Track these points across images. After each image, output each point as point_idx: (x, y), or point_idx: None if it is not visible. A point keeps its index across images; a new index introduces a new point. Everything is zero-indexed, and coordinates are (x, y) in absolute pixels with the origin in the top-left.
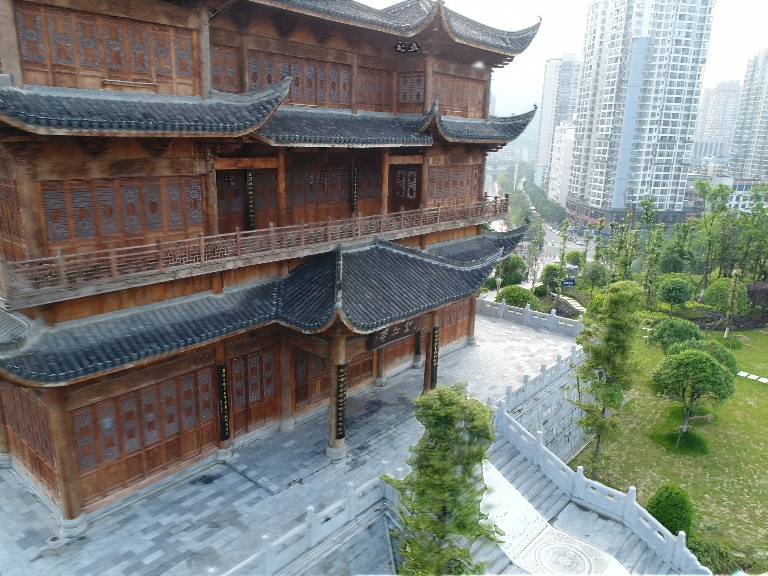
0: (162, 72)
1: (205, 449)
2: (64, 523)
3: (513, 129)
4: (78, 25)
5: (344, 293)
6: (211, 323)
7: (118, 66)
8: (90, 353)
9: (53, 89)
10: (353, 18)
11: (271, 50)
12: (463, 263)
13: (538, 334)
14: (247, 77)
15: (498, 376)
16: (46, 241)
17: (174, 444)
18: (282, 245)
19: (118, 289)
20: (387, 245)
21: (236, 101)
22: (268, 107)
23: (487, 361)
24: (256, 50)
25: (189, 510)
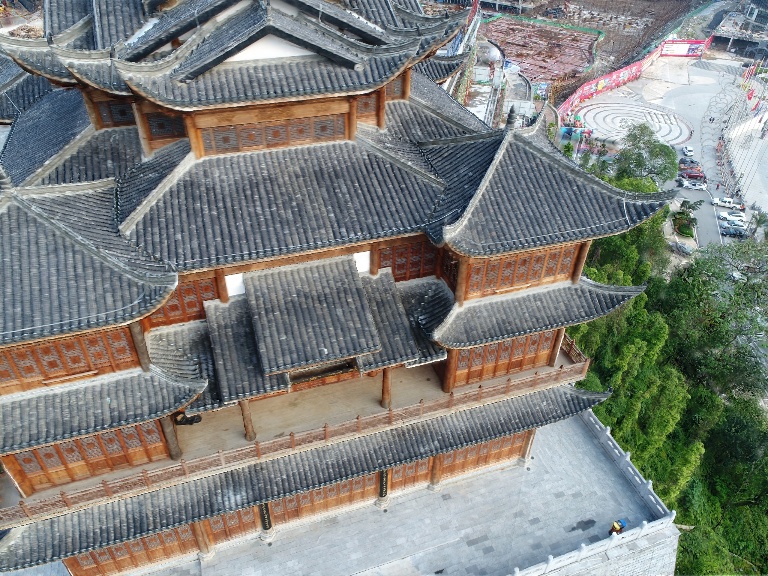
0: None
1: None
2: None
3: None
4: None
5: None
6: None
7: None
8: None
9: None
10: None
11: None
12: None
13: None
14: None
15: None
16: None
17: None
18: None
19: None
20: None
21: None
22: None
23: (38, 569)
24: None
25: None
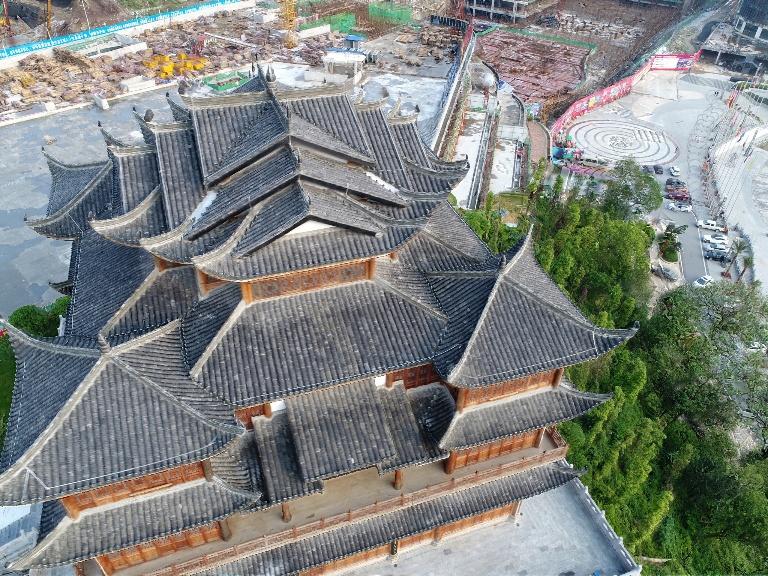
0: None
1: None
2: None
3: None
4: None
5: None
6: None
7: None
8: None
9: None
10: None
11: None
12: None
13: None
14: None
15: None
16: None
17: None
18: None
19: None
20: None
21: None
22: None
23: None
24: None
25: None
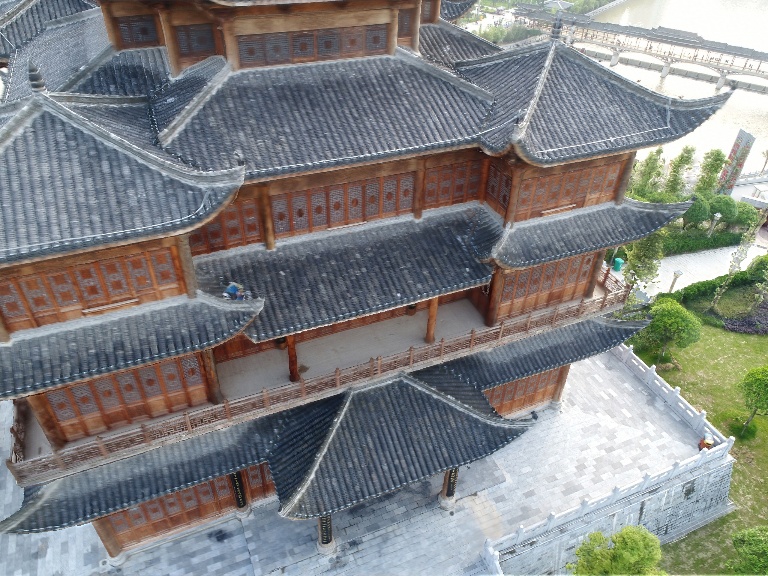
0: (142, 287)
1: (225, 510)
2: (108, 558)
3: (651, 221)
4: (50, 278)
5: (322, 464)
6: (204, 465)
7: (96, 295)
8: (94, 498)
9: (37, 331)
10: (398, 154)
11: (300, 188)
12: (490, 418)
13: (646, 409)
14: (269, 222)
15: (547, 476)
16: (57, 422)
17: (195, 511)
18: (279, 401)
19: (110, 461)
20: (412, 381)
21: (218, 304)
22: (241, 323)
23: (552, 444)
24: (280, 194)
25: (193, 569)
